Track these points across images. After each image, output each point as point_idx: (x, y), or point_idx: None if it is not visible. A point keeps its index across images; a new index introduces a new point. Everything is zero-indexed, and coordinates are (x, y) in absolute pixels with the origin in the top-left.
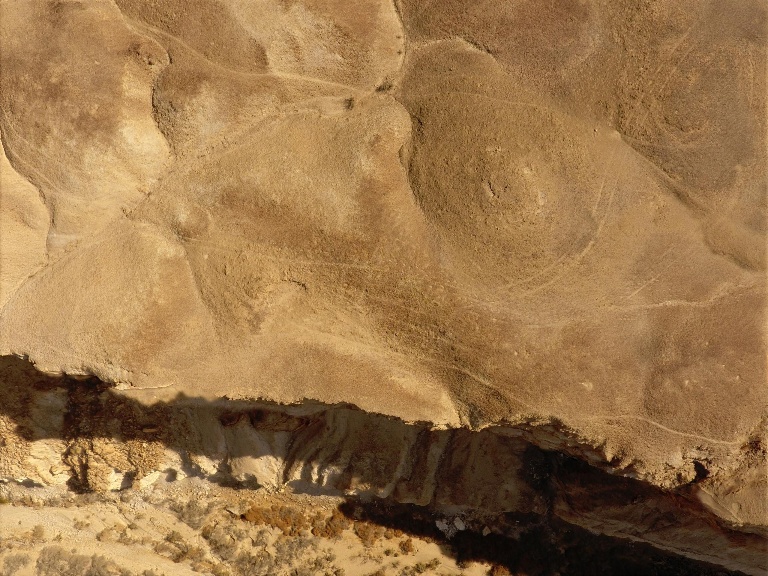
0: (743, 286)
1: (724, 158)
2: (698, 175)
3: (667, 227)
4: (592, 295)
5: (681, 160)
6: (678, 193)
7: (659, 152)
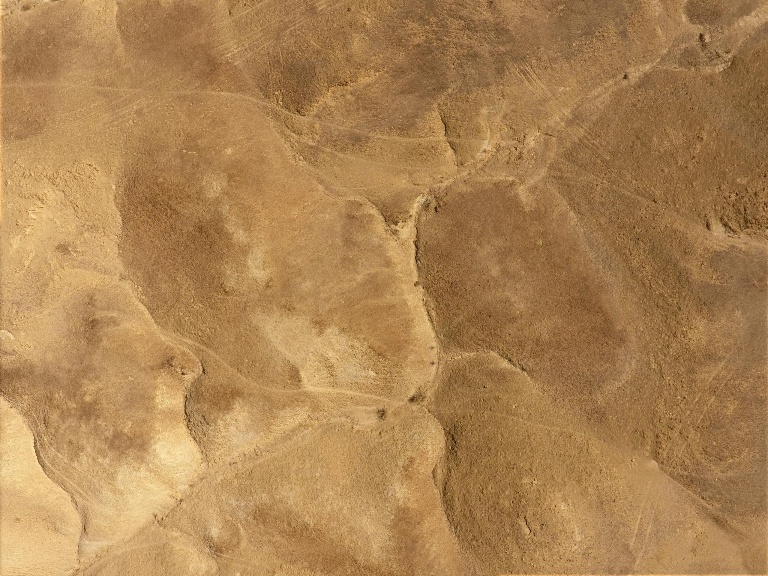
0: None
1: (763, 483)
2: (737, 502)
3: (705, 555)
4: None
5: (720, 489)
6: (716, 519)
7: (697, 481)
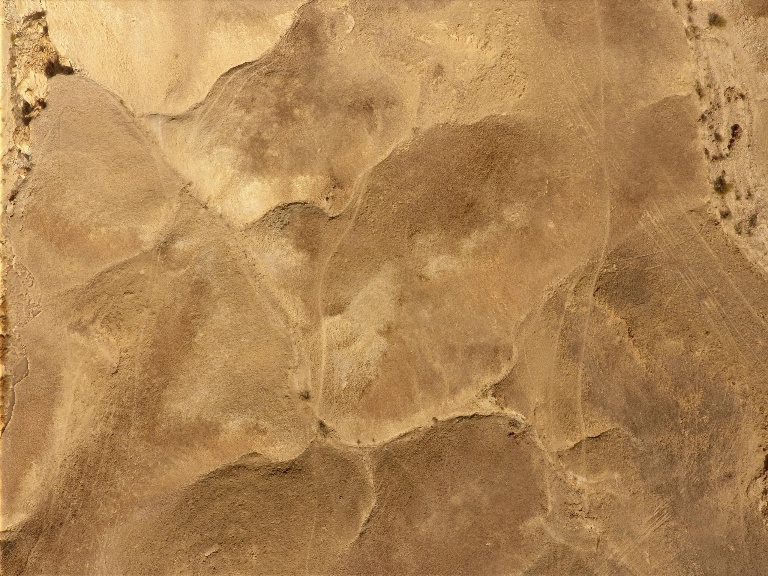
0: None
1: None
2: None
3: None
4: None
5: None
6: None
7: None
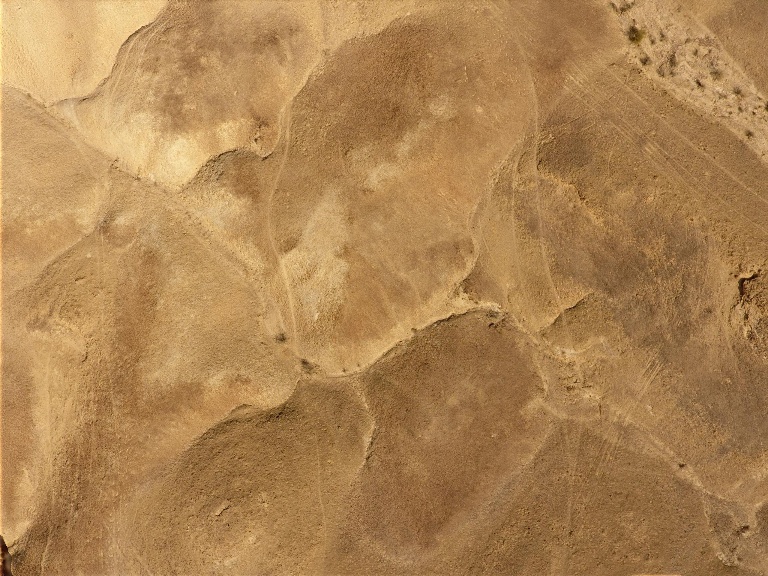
0: None
1: None
2: None
3: None
4: None
5: None
6: None
7: None
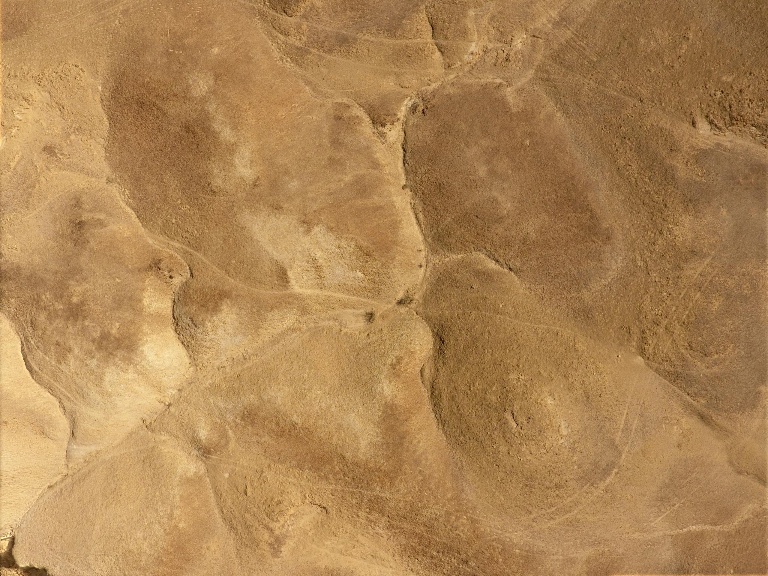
0: (767, 507)
1: (748, 380)
2: (722, 398)
3: (691, 451)
4: (616, 523)
5: (705, 384)
6: (702, 416)
7: (683, 377)
